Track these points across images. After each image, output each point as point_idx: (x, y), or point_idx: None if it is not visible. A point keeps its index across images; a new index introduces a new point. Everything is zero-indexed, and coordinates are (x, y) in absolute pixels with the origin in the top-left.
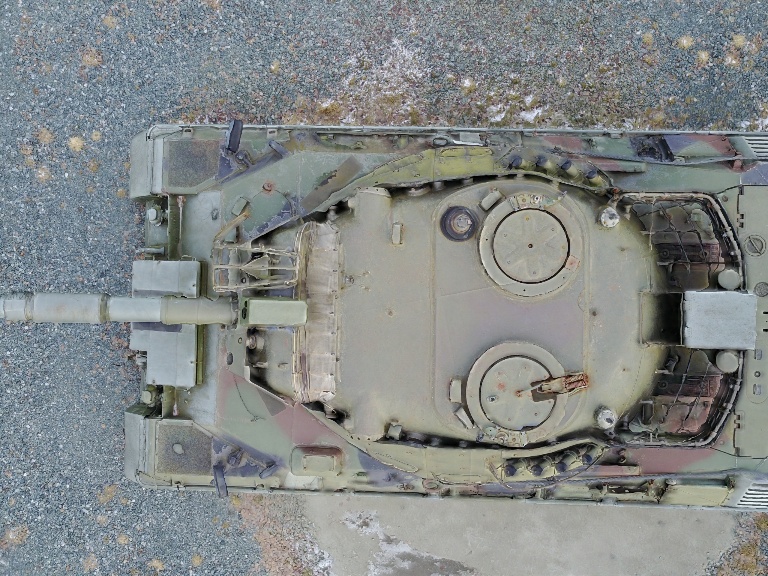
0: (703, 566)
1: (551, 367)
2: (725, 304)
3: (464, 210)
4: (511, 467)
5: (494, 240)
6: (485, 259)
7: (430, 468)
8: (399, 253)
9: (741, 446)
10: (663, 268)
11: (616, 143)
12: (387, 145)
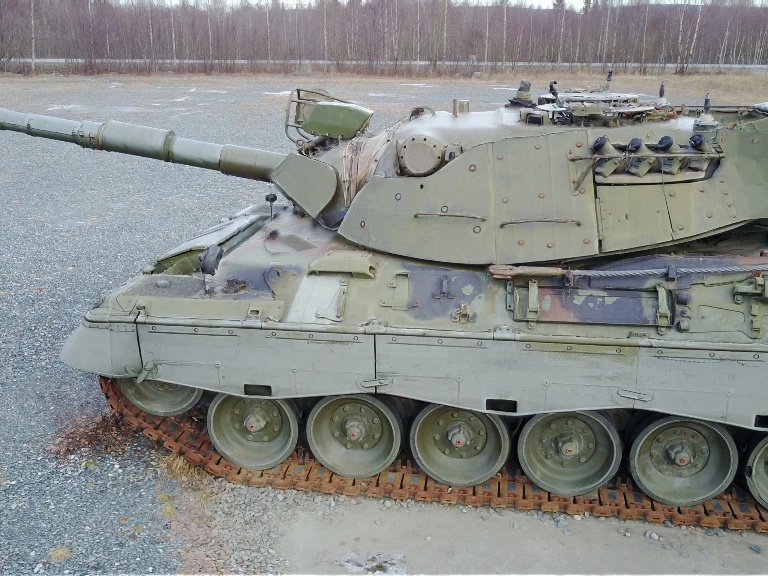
0: None
1: None
2: None
3: None
4: None
5: None
6: None
7: (499, 213)
8: None
9: None
10: None
11: None
12: None
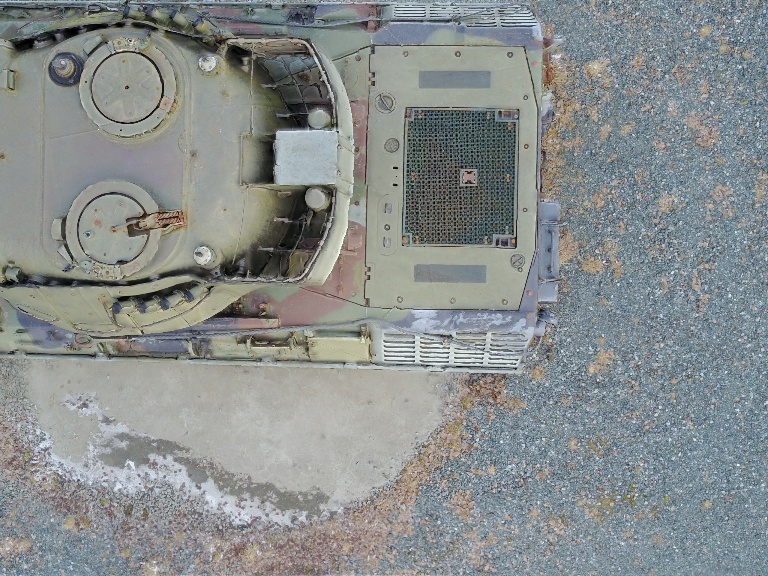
0: (412, 446)
1: (145, 204)
2: (309, 141)
3: (69, 56)
4: (116, 304)
5: (93, 82)
6: (84, 101)
7: (66, 317)
8: (12, 99)
9: (371, 297)
10: (286, 121)
11: (274, 13)
12: (52, 15)
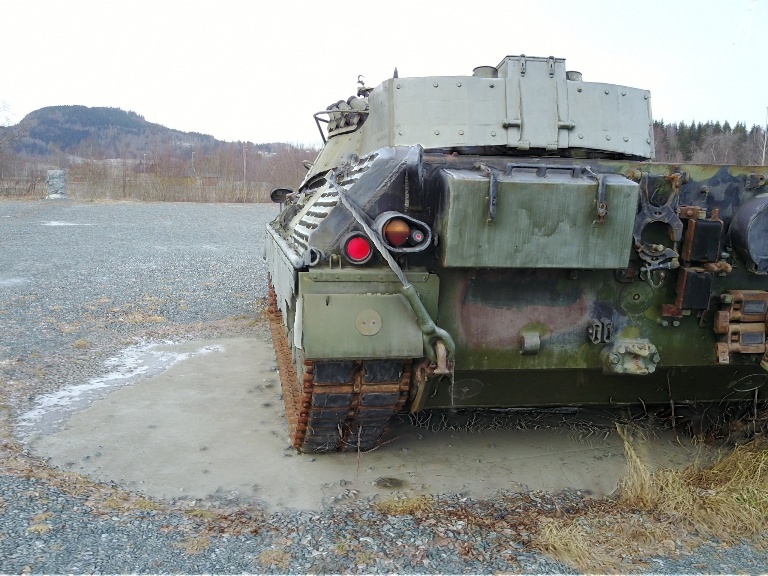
0: None
1: None
2: None
3: None
4: None
5: None
6: None
7: None
8: None
9: None
10: None
11: None
12: None
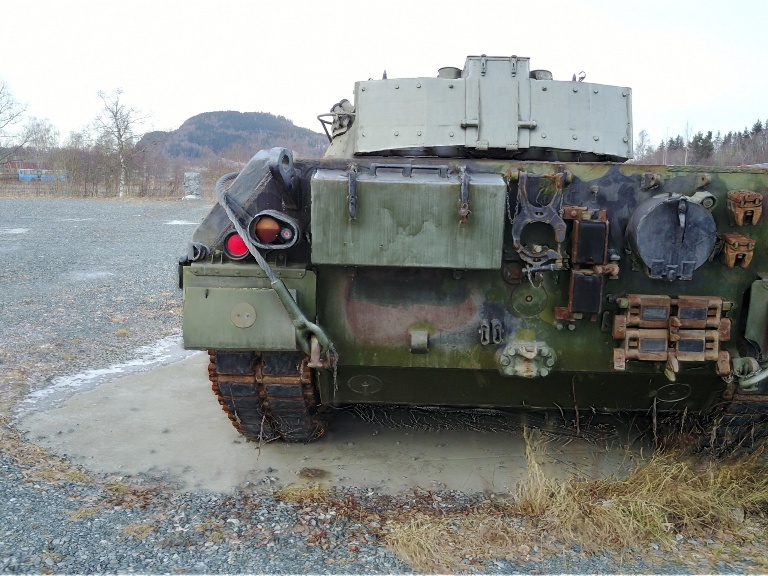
0: None
1: None
2: None
3: None
4: None
5: None
6: None
7: None
8: None
9: None
10: None
11: None
12: None
